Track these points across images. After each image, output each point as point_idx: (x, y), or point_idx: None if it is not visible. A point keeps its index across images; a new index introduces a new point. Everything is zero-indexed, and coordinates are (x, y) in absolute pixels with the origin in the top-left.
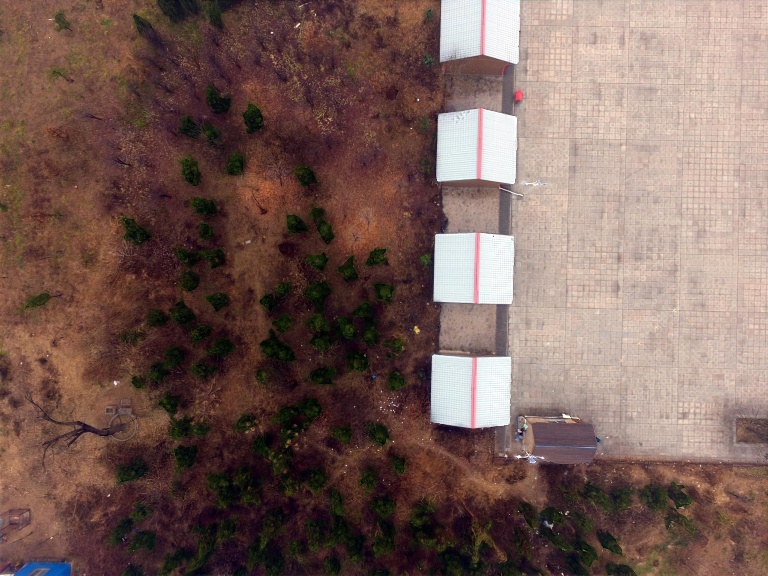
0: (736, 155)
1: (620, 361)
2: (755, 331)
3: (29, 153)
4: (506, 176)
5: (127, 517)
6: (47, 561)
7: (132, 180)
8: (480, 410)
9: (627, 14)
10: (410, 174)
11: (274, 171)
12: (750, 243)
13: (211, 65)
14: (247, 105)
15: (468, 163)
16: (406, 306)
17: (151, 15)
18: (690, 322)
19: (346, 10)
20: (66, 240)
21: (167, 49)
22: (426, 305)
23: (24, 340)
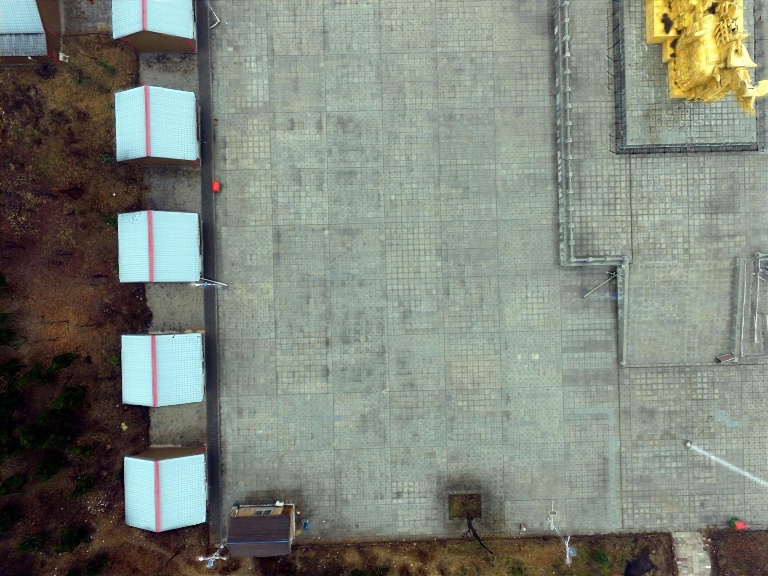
0: (437, 235)
1: (333, 445)
2: (464, 408)
3: None
4: (187, 274)
5: None
6: None
7: None
8: (165, 513)
9: (323, 99)
10: (108, 270)
11: None
12: (455, 321)
13: None
14: None
15: (142, 265)
16: (112, 403)
17: None
18: (400, 402)
19: (35, 106)
20: None
21: None
22: (115, 407)
23: None
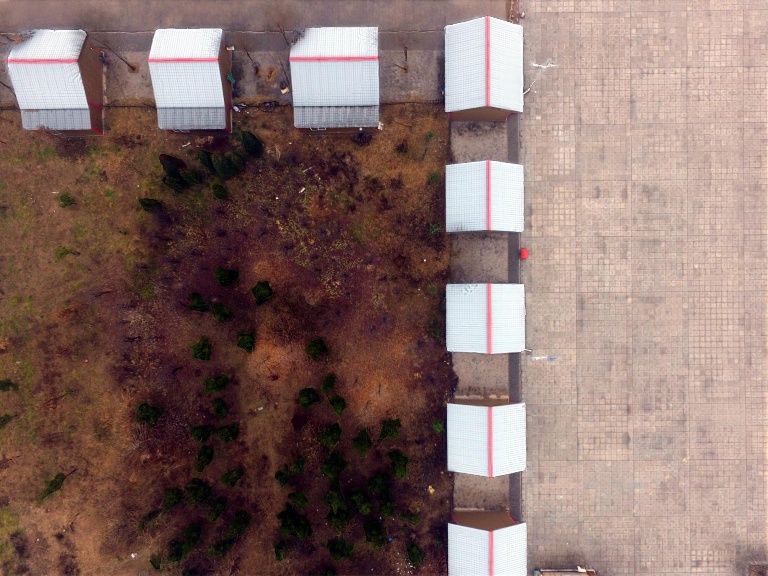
0: (740, 304)
1: (633, 512)
2: (764, 478)
3: (38, 328)
4: (516, 345)
5: None
6: None
7: (142, 352)
8: None
9: (629, 167)
10: (419, 335)
11: (284, 337)
12: (757, 391)
13: (217, 235)
14: (255, 273)
15: (478, 336)
16: (420, 466)
17: (155, 185)
18: (700, 471)
19: (350, 173)
20: (78, 414)
21: (173, 219)
22: (440, 474)
23: (40, 516)
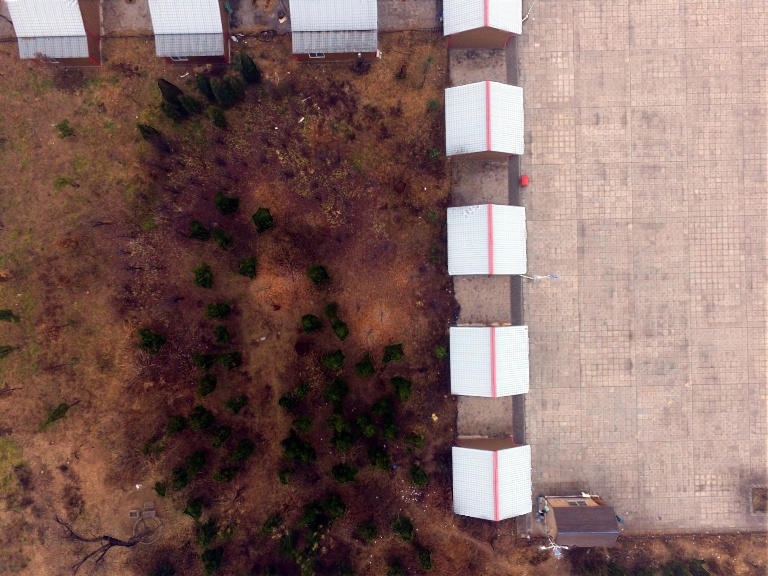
0: (741, 229)
1: (636, 437)
2: (767, 401)
3: (39, 261)
4: (517, 267)
5: None
6: None
7: (144, 283)
8: (503, 502)
9: (628, 94)
10: (421, 263)
11: (285, 267)
12: (758, 315)
13: (217, 164)
14: (255, 202)
15: (479, 258)
16: (423, 394)
17: (154, 116)
18: (703, 396)
19: (349, 102)
20: (81, 346)
21: (172, 150)
22: (444, 398)
23: (44, 448)
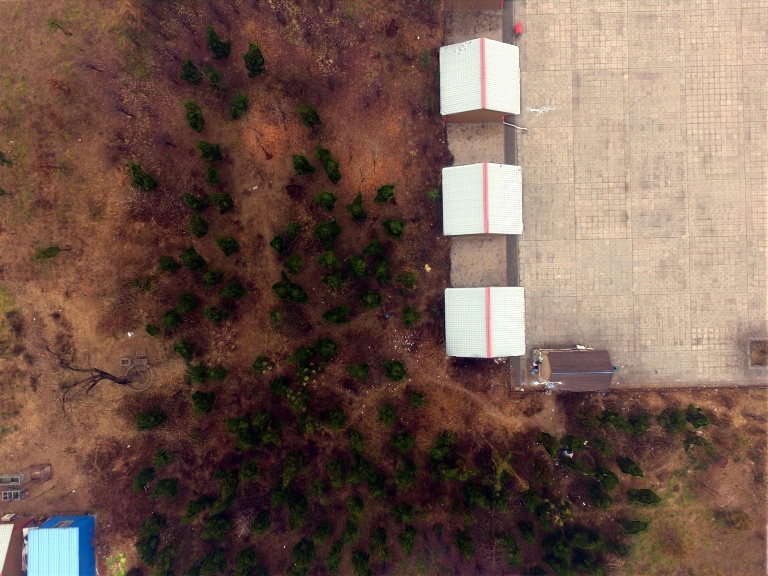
0: (739, 79)
1: (632, 290)
2: (765, 254)
3: (31, 109)
4: (511, 106)
5: (148, 466)
6: (70, 514)
7: (136, 131)
8: (495, 340)
9: None
10: (414, 112)
11: (277, 116)
12: (756, 166)
13: (209, 12)
14: (247, 50)
15: (472, 94)
16: (416, 245)
17: None
18: (700, 248)
19: None
20: (73, 194)
21: None
22: (436, 239)
23: (36, 296)
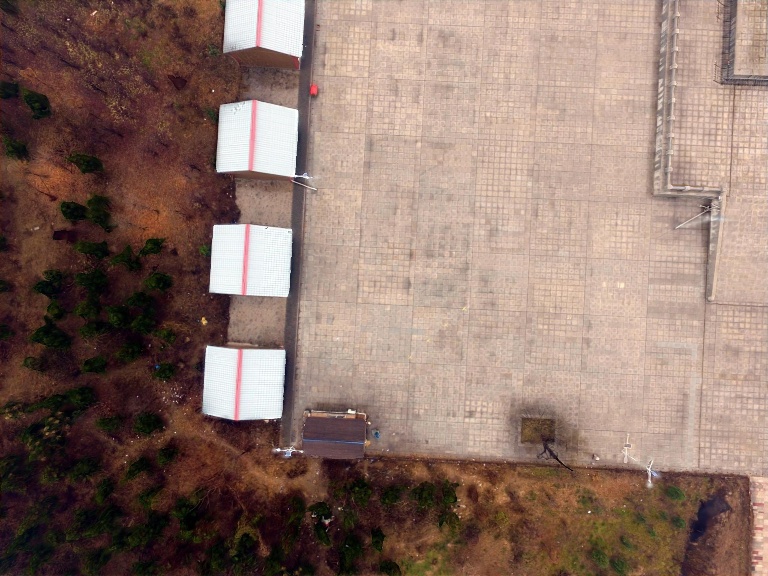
0: (530, 155)
1: (409, 358)
2: (544, 331)
3: None
4: (284, 169)
5: None
6: None
7: None
8: (245, 402)
9: (426, 11)
10: (201, 165)
11: (65, 158)
12: (542, 243)
13: (3, 50)
14: (39, 91)
15: (242, 154)
16: (194, 297)
17: None
18: (480, 321)
19: None
20: None
21: None
22: (201, 296)
23: None
